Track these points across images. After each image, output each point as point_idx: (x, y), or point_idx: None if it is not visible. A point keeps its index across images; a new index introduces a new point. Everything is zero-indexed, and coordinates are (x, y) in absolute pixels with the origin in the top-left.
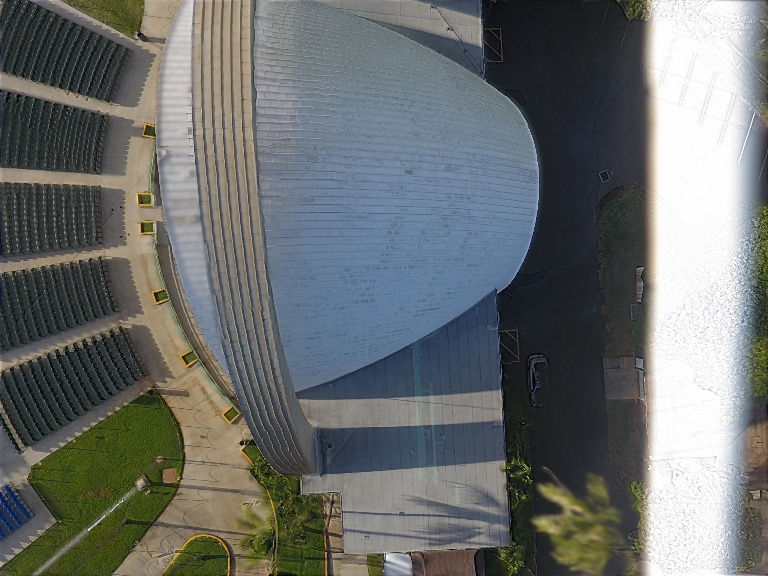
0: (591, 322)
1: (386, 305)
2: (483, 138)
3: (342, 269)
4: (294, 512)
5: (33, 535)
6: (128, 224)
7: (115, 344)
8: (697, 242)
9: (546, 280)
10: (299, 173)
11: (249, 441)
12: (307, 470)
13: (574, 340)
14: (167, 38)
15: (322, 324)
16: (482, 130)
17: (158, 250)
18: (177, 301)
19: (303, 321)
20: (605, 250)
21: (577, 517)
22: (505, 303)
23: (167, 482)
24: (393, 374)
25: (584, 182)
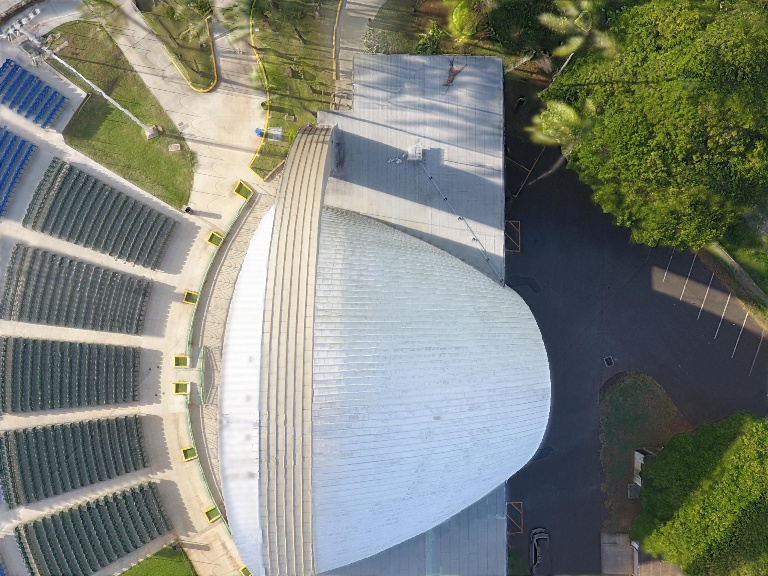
0: (591, 498)
1: (408, 523)
2: (503, 371)
3: (372, 505)
4: None
5: None
6: (164, 384)
7: (143, 499)
8: (692, 452)
9: (551, 456)
10: (341, 432)
11: None
12: None
13: (574, 514)
14: (231, 306)
15: (349, 544)
16: (503, 363)
17: (190, 410)
18: (204, 459)
19: (333, 545)
20: (607, 431)
21: None
22: (512, 476)
23: None
24: (406, 557)
25: (590, 366)
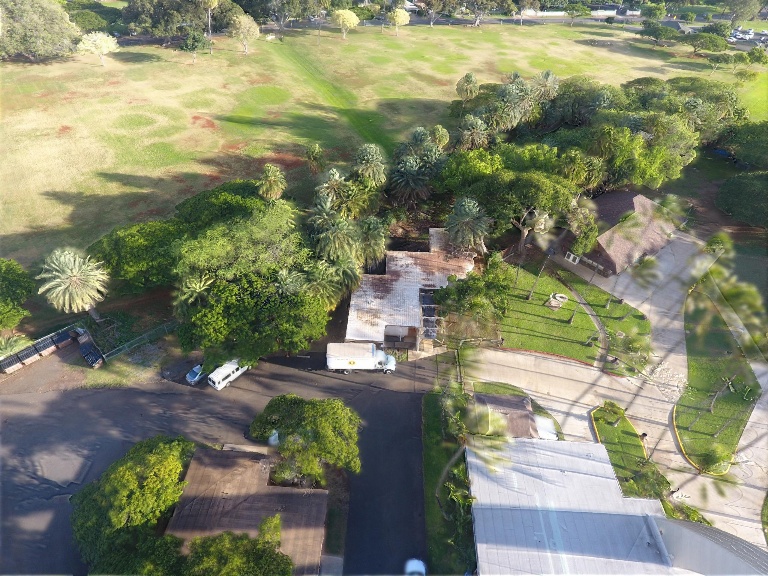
0: None
1: None
2: None
3: None
4: (658, 485)
5: None
6: None
7: None
8: None
9: None
10: None
11: None
12: None
13: None
14: None
15: None
16: None
17: None
18: None
19: None
20: None
21: (385, 449)
22: None
23: None
24: None
25: None
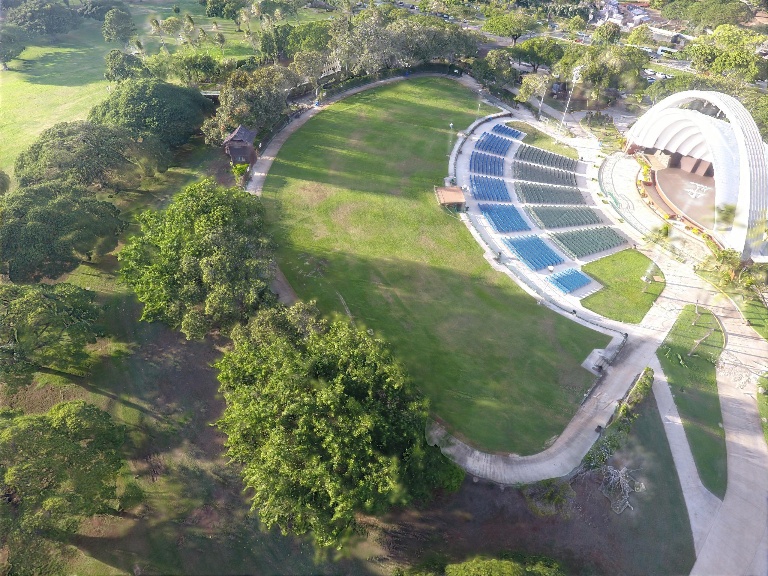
0: None
1: None
2: None
3: None
4: None
5: (593, 290)
6: (595, 200)
7: None
8: None
9: None
10: None
11: (696, 269)
12: (759, 240)
13: None
14: None
15: None
16: None
17: None
18: None
19: None
20: None
21: None
22: None
23: (658, 281)
24: None
25: None
